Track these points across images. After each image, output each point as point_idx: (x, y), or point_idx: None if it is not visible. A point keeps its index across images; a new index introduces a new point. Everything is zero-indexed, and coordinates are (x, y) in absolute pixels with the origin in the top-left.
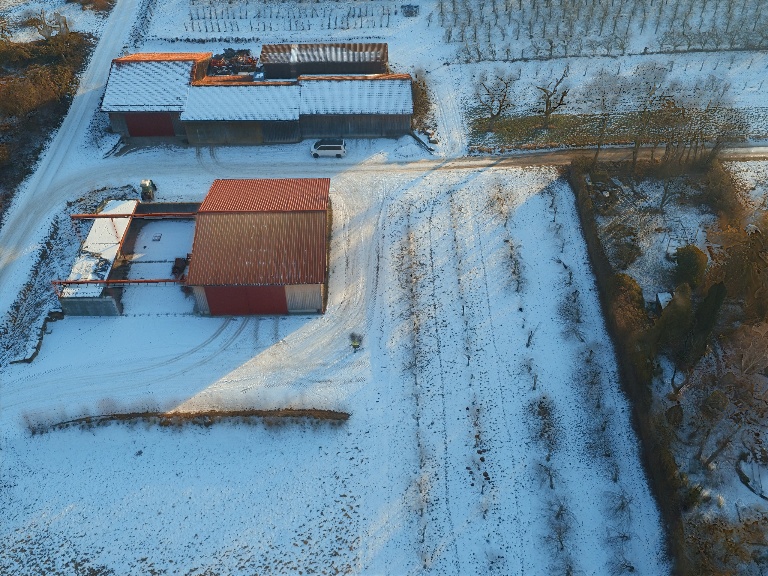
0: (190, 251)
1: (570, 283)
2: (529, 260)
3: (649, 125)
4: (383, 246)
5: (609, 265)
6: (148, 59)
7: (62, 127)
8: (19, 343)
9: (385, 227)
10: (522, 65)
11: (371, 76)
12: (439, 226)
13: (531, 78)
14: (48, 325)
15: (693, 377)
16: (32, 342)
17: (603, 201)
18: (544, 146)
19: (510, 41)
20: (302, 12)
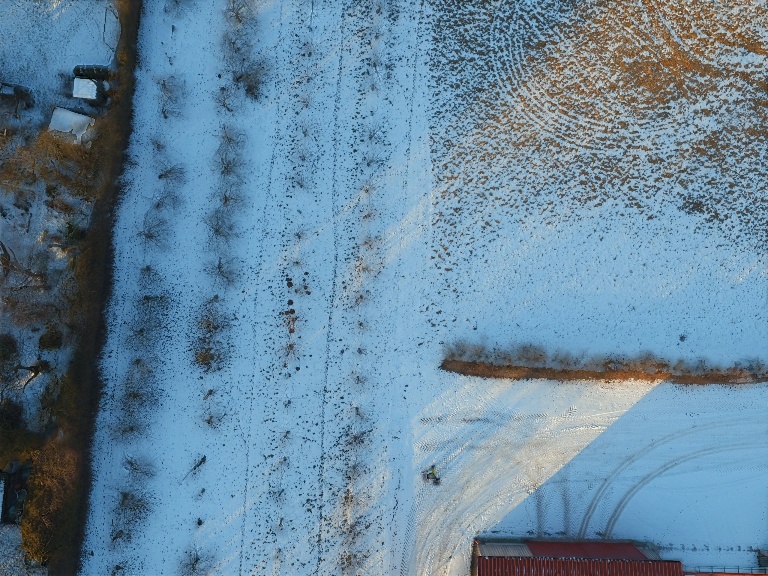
0: None
1: (118, 568)
2: None
3: None
4: None
5: None
6: None
7: None
8: None
9: None
10: None
11: None
12: None
13: None
14: None
15: (6, 395)
16: None
17: None
18: None
19: None
20: None
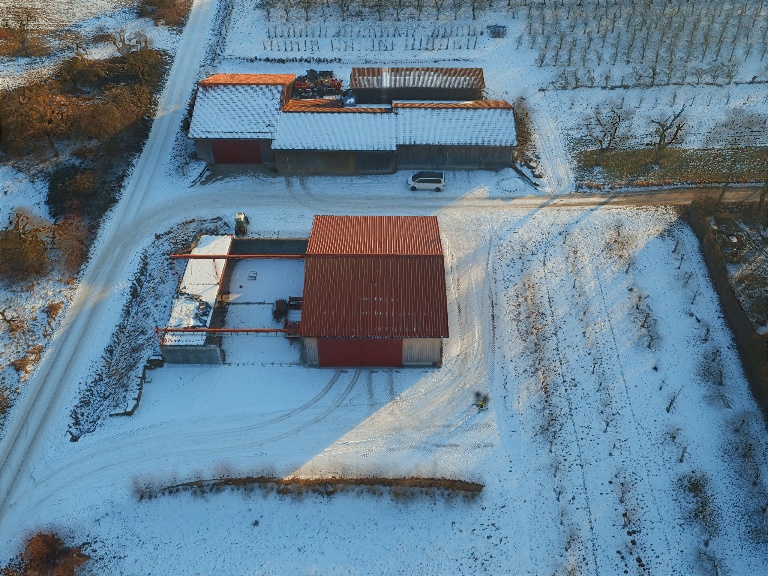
0: (289, 292)
1: (706, 340)
2: (658, 312)
3: (767, 162)
4: (496, 292)
5: (750, 321)
6: (235, 82)
7: (144, 152)
8: (118, 393)
9: (496, 270)
10: (622, 93)
11: (468, 104)
12: (555, 271)
13: (634, 107)
14: (147, 373)
15: None
16: (132, 393)
17: (730, 247)
18: (657, 183)
19: (606, 66)
20: (383, 31)
